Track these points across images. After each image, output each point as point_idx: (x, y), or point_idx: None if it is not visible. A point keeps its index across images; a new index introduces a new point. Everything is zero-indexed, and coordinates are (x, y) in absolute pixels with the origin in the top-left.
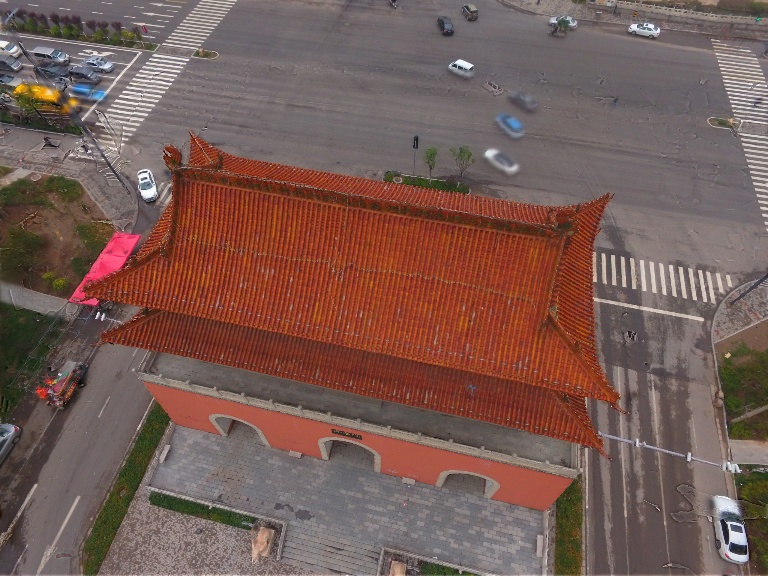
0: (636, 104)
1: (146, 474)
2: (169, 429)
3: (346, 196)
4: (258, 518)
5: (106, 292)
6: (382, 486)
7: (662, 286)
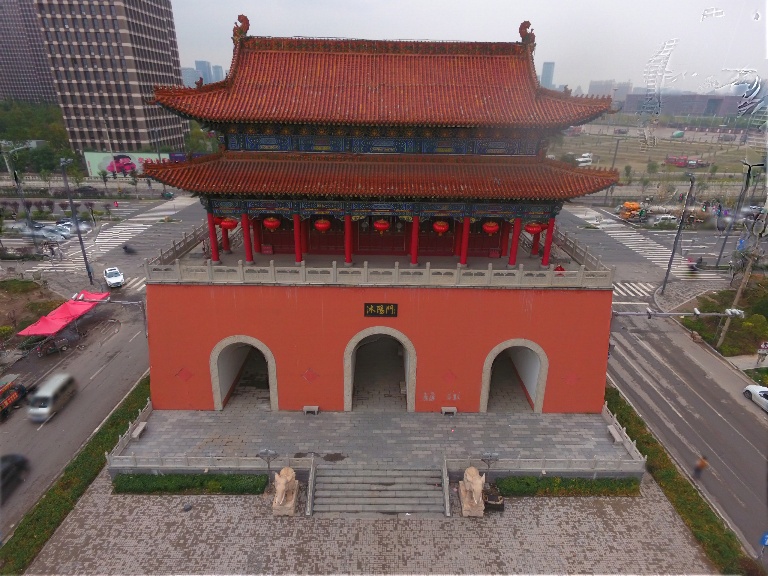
0: None
1: (105, 467)
2: (145, 408)
3: (374, 42)
4: (274, 472)
5: (172, 101)
6: (421, 421)
7: None
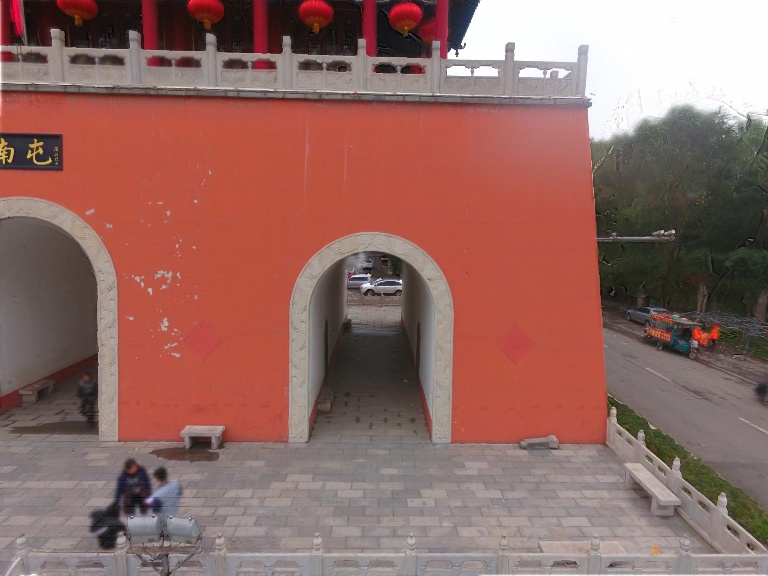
0: None
1: None
2: None
3: None
4: None
5: None
6: None
7: None
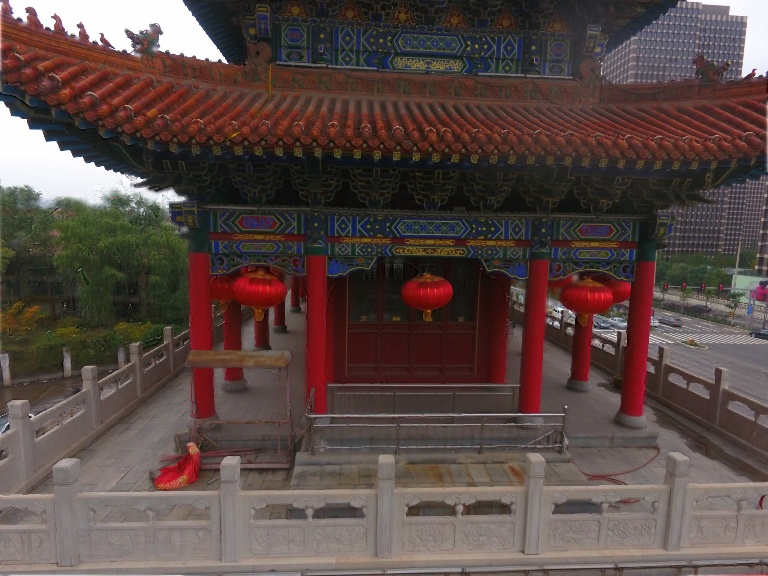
0: None
1: None
2: None
3: None
4: None
5: None
6: None
7: None
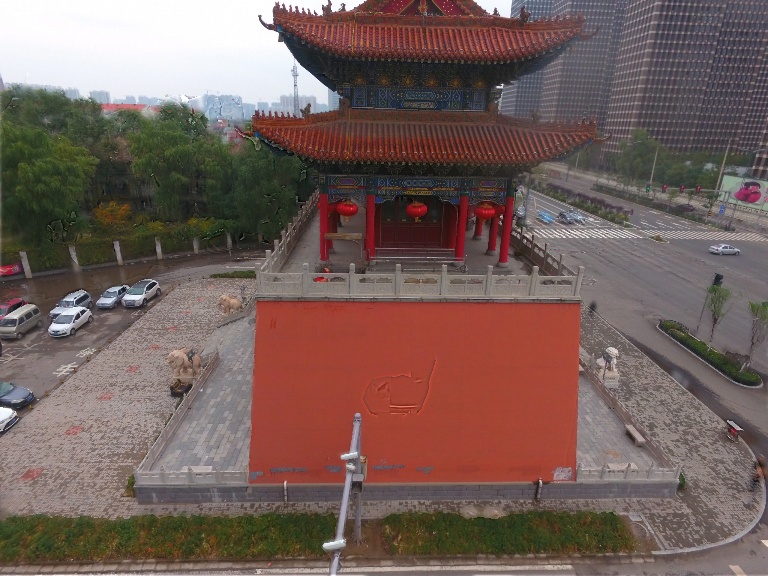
0: None
1: None
2: None
3: None
4: None
5: None
6: None
7: None
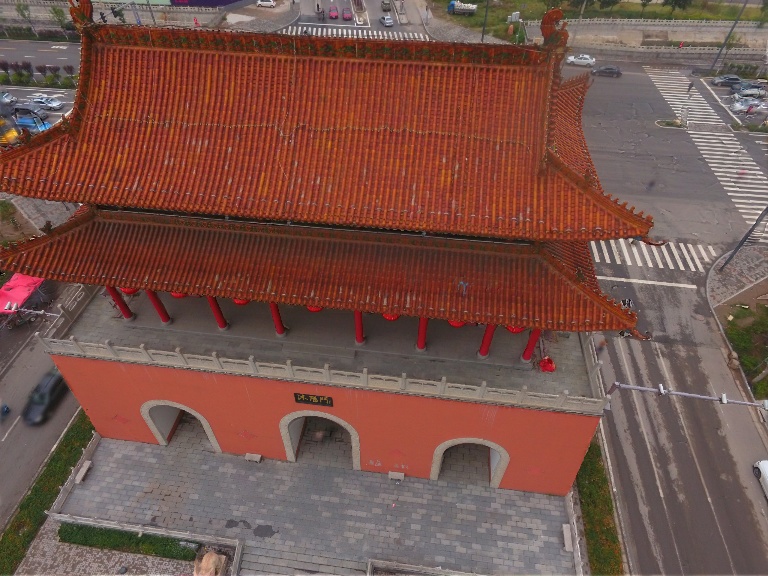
0: (586, 114)
1: None
2: (91, 441)
3: (292, 38)
4: (204, 542)
5: None
6: (364, 486)
7: (646, 259)
